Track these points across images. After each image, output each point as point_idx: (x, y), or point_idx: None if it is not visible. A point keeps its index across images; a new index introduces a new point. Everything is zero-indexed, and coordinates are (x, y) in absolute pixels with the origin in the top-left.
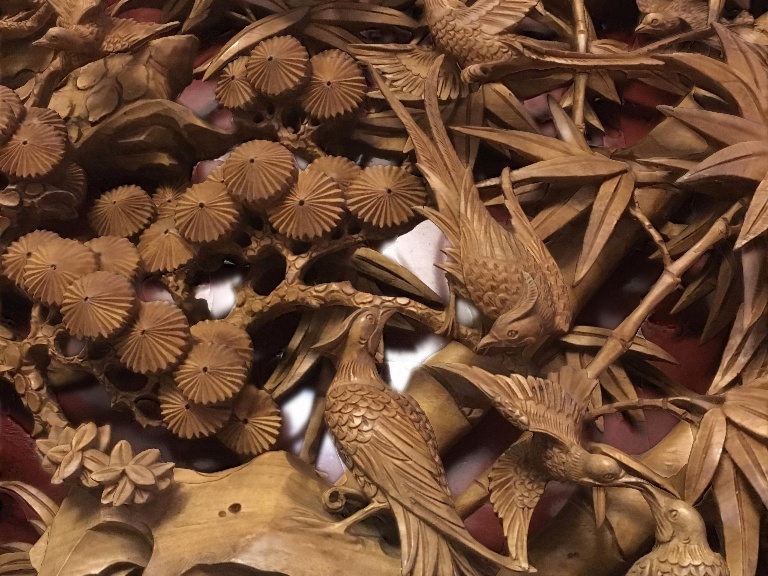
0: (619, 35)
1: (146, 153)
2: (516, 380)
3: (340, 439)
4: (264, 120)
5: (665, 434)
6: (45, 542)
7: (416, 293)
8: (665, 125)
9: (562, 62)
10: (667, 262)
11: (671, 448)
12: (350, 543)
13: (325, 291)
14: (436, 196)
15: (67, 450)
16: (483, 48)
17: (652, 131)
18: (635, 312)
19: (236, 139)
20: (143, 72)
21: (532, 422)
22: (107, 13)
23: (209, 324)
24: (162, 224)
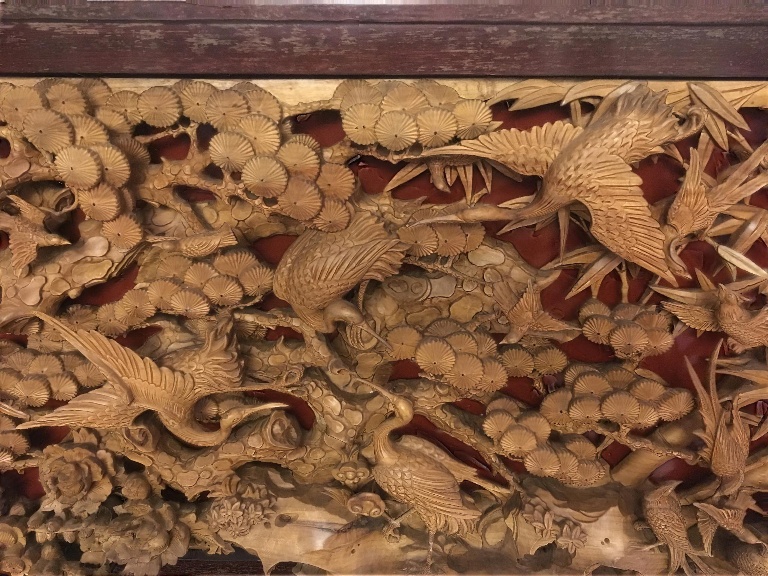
0: None
1: None
2: (727, 512)
3: (654, 529)
4: None
5: (758, 451)
6: (511, 518)
7: None
8: None
9: None
10: None
11: (763, 474)
12: (650, 552)
13: (640, 447)
14: (706, 427)
15: (543, 527)
16: (746, 341)
17: None
18: None
19: None
20: None
21: (729, 526)
22: None
23: (578, 445)
24: (556, 402)
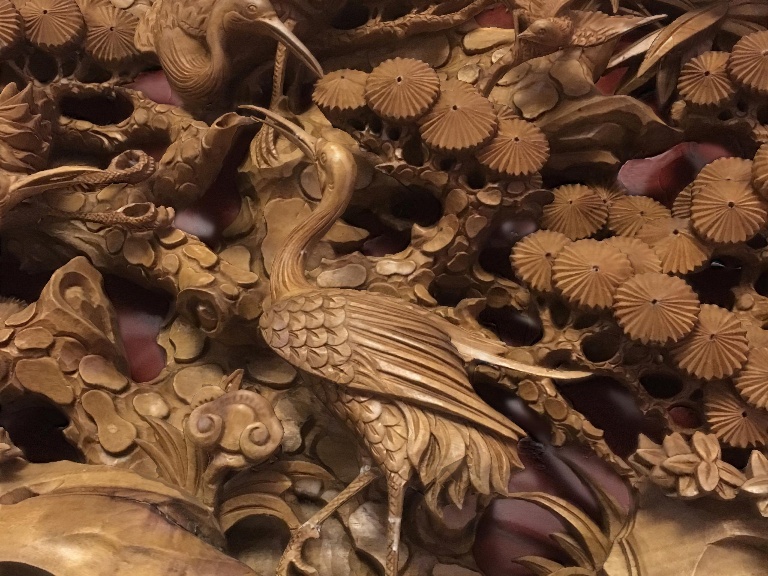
0: None
1: (585, 151)
2: None
3: None
4: (734, 117)
5: None
6: (618, 556)
7: None
8: None
9: None
10: None
11: None
12: None
13: None
14: None
15: (695, 460)
16: None
17: None
18: None
19: (684, 137)
20: (579, 67)
21: None
22: (488, 8)
23: None
24: (661, 224)
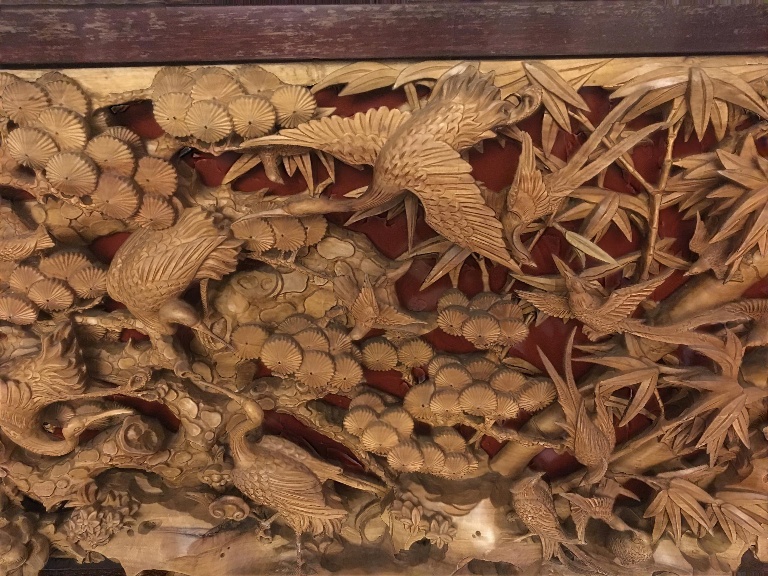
0: (671, 230)
1: None
2: (593, 500)
3: (522, 520)
4: None
5: (636, 435)
6: (387, 514)
7: (530, 373)
8: (681, 315)
9: (640, 336)
10: (662, 415)
11: (639, 459)
12: (522, 543)
13: (506, 438)
14: None
15: (411, 524)
16: (599, 328)
17: (673, 315)
18: (642, 441)
19: None
20: (385, 293)
21: (597, 515)
22: None
23: (446, 438)
24: (418, 396)
